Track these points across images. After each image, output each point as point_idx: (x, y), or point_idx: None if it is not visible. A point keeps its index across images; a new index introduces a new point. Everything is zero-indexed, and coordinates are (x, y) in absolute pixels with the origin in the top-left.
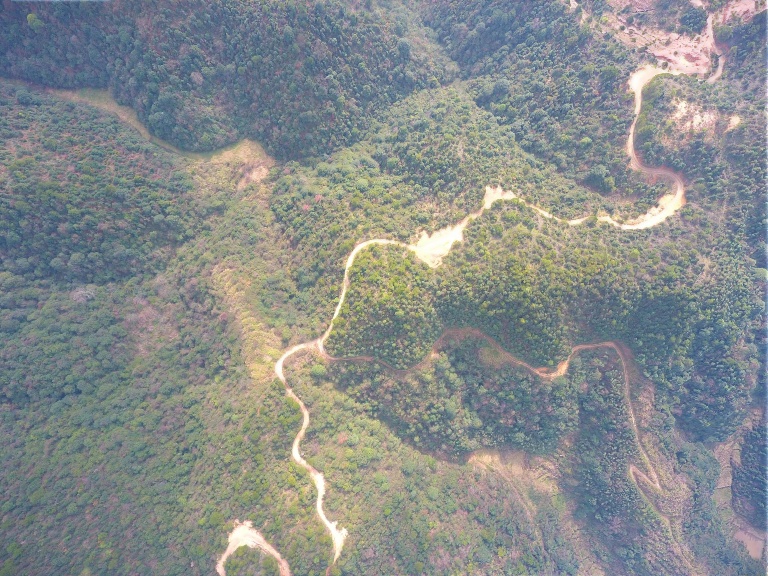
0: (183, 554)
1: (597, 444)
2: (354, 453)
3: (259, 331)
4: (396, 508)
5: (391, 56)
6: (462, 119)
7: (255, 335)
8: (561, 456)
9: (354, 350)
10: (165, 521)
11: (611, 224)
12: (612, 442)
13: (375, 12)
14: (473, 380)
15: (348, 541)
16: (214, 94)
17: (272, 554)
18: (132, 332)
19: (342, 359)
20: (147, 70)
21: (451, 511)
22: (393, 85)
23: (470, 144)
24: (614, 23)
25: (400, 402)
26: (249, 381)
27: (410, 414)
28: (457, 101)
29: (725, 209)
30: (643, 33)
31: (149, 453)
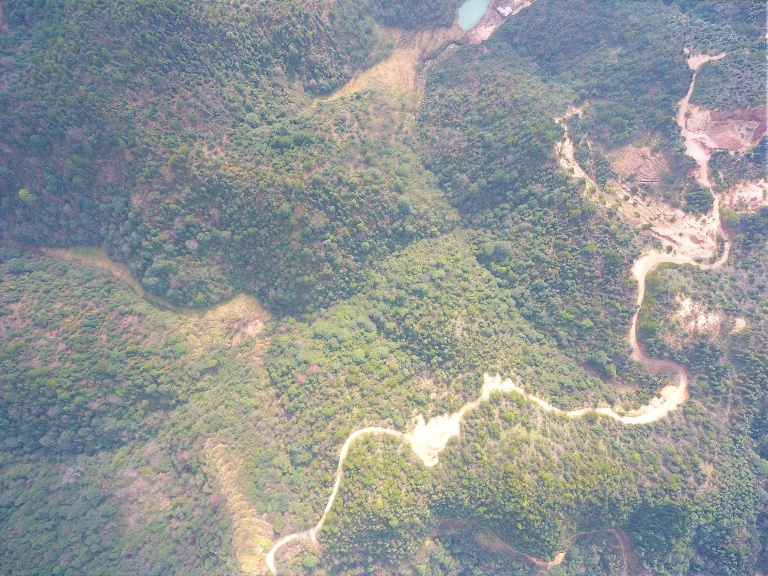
0: None
1: None
2: None
3: (251, 519)
4: None
5: (390, 213)
6: (461, 288)
7: (246, 523)
8: None
9: (347, 546)
10: None
11: (612, 418)
12: None
13: (374, 172)
14: (468, 561)
15: None
16: (209, 255)
17: None
18: (122, 507)
19: None
20: (141, 240)
21: None
22: (392, 238)
23: (469, 321)
24: (618, 191)
25: None
26: (239, 575)
27: None
28: (457, 260)
29: (729, 411)
30: (648, 205)
31: None
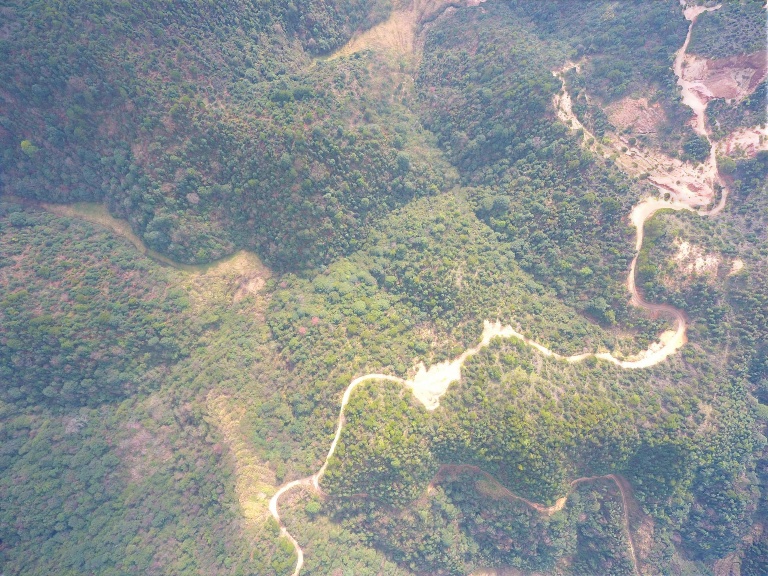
0: None
1: (595, 569)
2: None
3: (253, 466)
4: None
5: (390, 169)
6: (461, 240)
7: (249, 470)
8: (559, 574)
9: (349, 491)
10: None
11: (611, 363)
12: (610, 569)
13: (374, 127)
14: (470, 510)
15: None
16: (210, 210)
17: None
18: (125, 458)
19: None
20: (142, 193)
21: None
22: (392, 195)
23: (469, 271)
24: (616, 143)
25: (396, 535)
26: (243, 521)
27: (406, 545)
28: (456, 215)
29: (727, 353)
30: (645, 156)
31: None
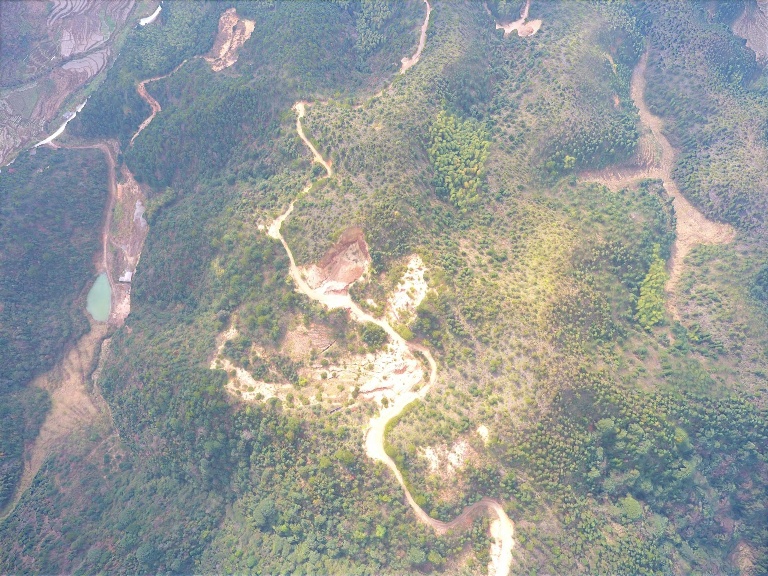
0: None
1: None
2: None
3: None
4: None
5: (142, 574)
6: None
7: None
8: None
9: None
10: None
11: None
12: None
13: None
14: None
15: None
16: None
17: None
18: None
19: None
20: None
21: None
22: None
23: None
24: (314, 375)
25: None
26: None
27: None
28: (240, 556)
29: (550, 510)
30: (344, 368)
31: None
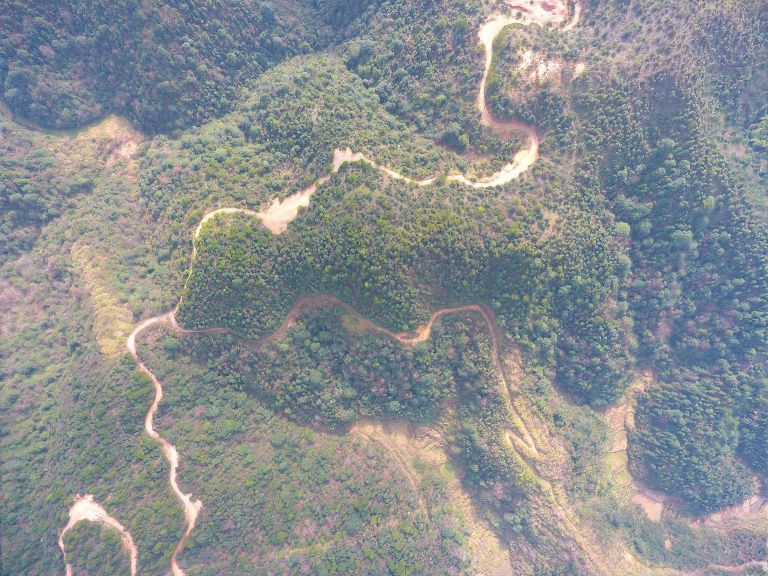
0: (34, 530)
1: (473, 410)
2: (212, 425)
3: (111, 306)
4: (261, 479)
5: (254, 21)
6: (322, 82)
7: (107, 310)
8: (445, 424)
9: (202, 321)
10: (13, 498)
11: (462, 183)
12: (487, 407)
13: None
14: (338, 349)
15: (202, 512)
16: (70, 68)
17: (116, 527)
18: None
19: (196, 331)
20: None
21: (322, 481)
22: (262, 52)
23: (325, 107)
24: None
25: (261, 373)
26: (99, 357)
27: (274, 385)
28: (324, 65)
29: (574, 161)
30: None
31: (1, 432)
